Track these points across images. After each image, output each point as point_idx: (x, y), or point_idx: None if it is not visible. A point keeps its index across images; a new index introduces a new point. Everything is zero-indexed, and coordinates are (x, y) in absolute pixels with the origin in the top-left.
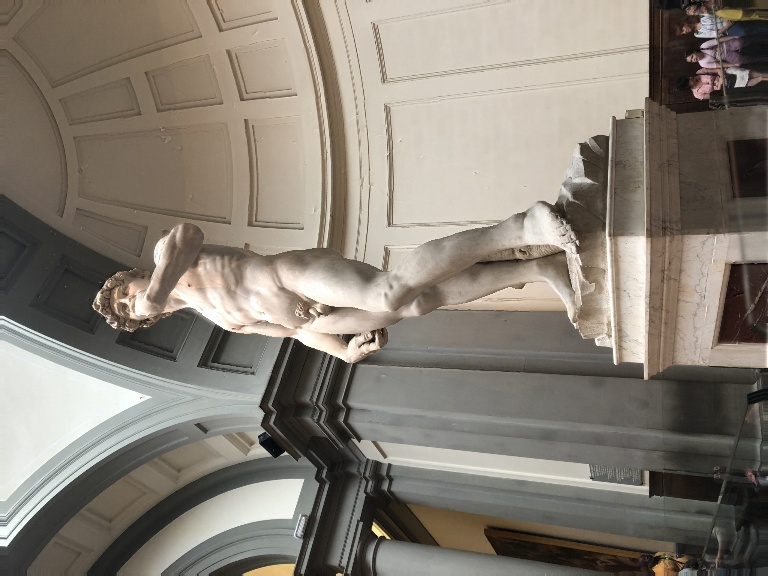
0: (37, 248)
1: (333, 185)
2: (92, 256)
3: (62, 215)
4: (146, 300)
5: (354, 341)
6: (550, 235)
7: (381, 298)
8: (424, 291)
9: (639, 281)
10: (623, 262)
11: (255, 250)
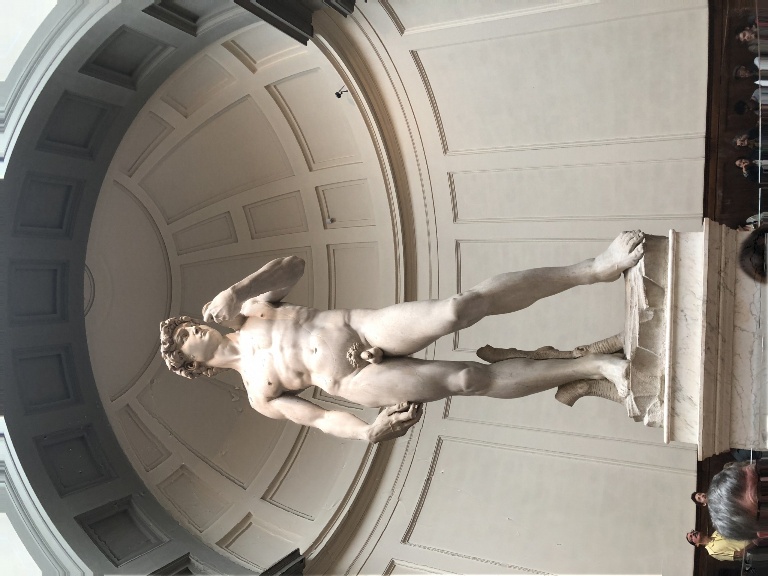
0: (77, 404)
1: (363, 486)
2: (112, 441)
3: (113, 400)
4: (230, 289)
5: (386, 409)
6: (619, 252)
7: (449, 302)
8: (476, 366)
9: (696, 296)
10: (683, 267)
11: (255, 523)
